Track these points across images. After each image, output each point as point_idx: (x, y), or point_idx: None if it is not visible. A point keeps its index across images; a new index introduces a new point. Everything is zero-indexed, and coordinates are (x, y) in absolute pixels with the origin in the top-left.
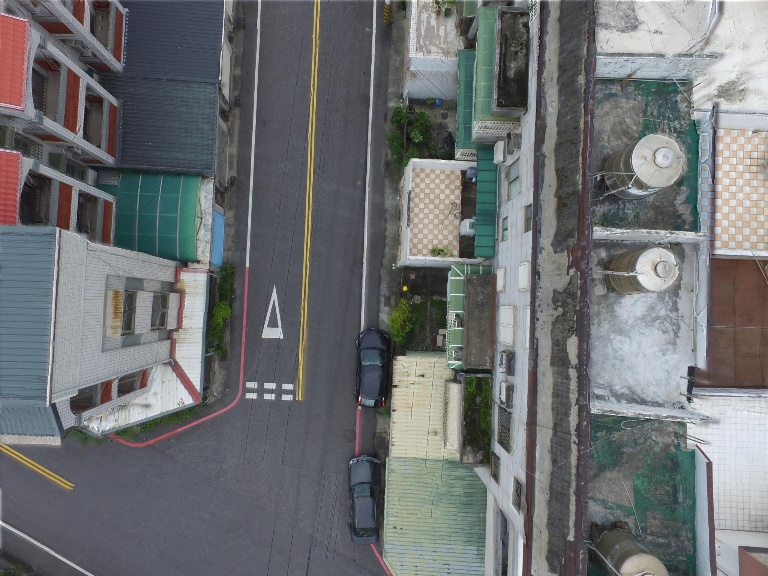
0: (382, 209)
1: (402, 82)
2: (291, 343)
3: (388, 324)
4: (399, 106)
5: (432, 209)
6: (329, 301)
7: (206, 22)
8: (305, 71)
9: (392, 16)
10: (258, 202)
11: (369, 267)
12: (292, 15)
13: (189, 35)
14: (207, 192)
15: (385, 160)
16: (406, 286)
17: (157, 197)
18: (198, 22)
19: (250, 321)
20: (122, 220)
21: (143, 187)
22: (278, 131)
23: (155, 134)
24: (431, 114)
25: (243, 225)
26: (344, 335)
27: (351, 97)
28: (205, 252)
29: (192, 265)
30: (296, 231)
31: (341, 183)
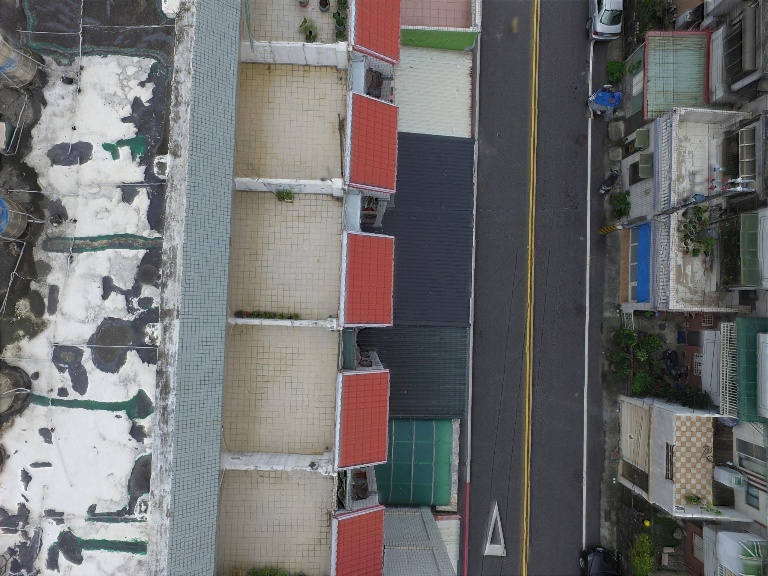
0: (601, 421)
1: (618, 292)
2: (514, 562)
3: (610, 540)
4: (615, 316)
5: (684, 452)
6: (550, 517)
7: (456, 265)
8: (521, 281)
9: (606, 225)
10: (476, 415)
11: (589, 481)
12: (506, 225)
13: (440, 279)
14: (453, 432)
15: (602, 371)
16: (648, 520)
17: (411, 445)
18: (448, 266)
19: (472, 539)
20: (377, 469)
21: (396, 434)
22: (495, 343)
23: (410, 382)
24: (648, 325)
25: (462, 439)
26: (566, 552)
27: (568, 308)
28: (452, 493)
29: (440, 507)
30: (515, 445)
31: (560, 396)
